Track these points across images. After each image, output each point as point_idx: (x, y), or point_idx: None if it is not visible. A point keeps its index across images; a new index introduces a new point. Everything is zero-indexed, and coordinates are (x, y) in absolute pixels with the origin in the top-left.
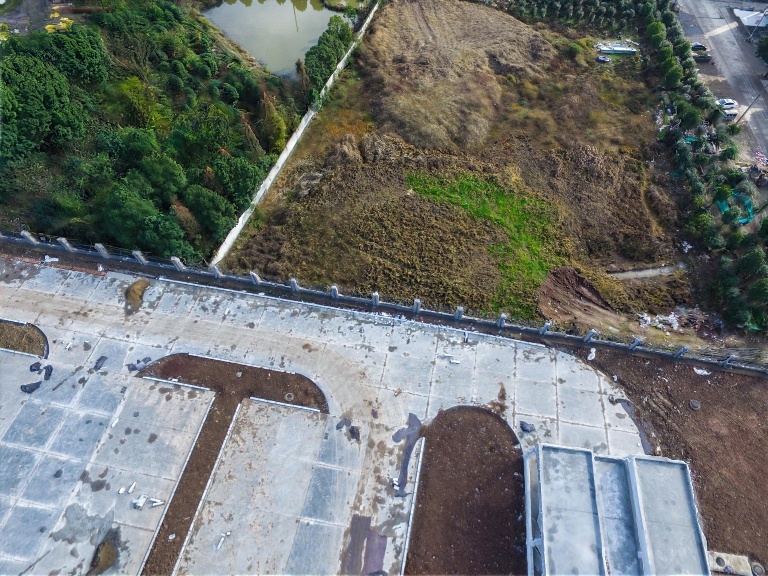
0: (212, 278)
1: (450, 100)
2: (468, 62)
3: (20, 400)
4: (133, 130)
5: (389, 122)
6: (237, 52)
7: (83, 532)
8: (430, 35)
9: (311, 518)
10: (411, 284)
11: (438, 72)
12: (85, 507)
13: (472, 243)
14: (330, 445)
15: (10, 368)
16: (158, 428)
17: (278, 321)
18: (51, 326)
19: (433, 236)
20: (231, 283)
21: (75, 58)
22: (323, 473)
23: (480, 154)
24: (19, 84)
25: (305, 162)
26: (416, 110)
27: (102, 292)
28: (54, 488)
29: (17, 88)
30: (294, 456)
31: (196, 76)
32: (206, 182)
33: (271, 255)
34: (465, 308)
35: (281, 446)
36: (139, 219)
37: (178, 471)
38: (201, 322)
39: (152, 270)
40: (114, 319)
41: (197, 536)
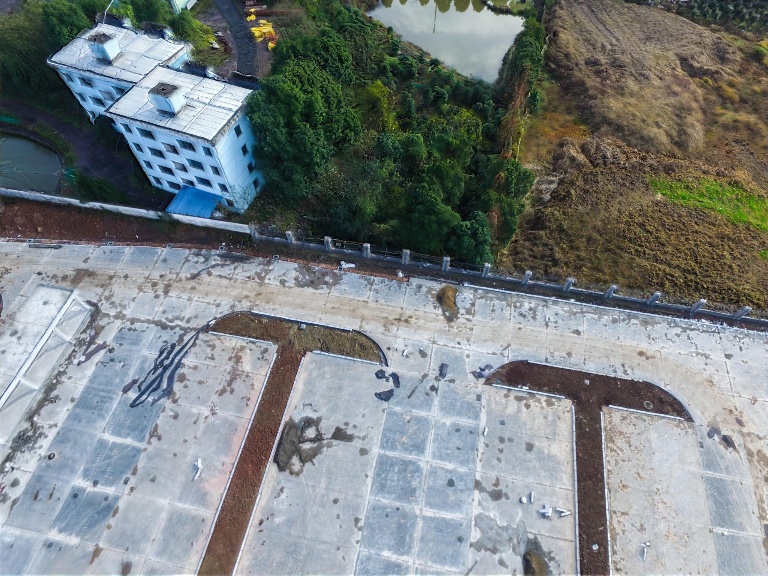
0: (519, 284)
1: (661, 103)
2: (664, 65)
3: (380, 408)
4: (405, 135)
5: (604, 125)
6: (422, 54)
7: (502, 542)
8: (612, 37)
9: (723, 528)
10: (698, 290)
11: (641, 75)
12: (493, 517)
13: (743, 248)
14: (710, 454)
15: (356, 375)
16: (531, 437)
17: (602, 328)
18: (378, 333)
19: (702, 241)
20: (539, 289)
21: (337, 62)
22: (715, 482)
23: (704, 158)
24: (322, 89)
25: (533, 166)
26: (631, 113)
27: (414, 298)
28: (453, 497)
29: (321, 93)
30: (679, 465)
31: (400, 79)
32: (495, 187)
33: (545, 260)
34: (764, 314)
35: (661, 455)
36: (452, 225)
37: (571, 480)
38: (526, 329)
39: (455, 276)
40: (438, 326)
41: (618, 546)
